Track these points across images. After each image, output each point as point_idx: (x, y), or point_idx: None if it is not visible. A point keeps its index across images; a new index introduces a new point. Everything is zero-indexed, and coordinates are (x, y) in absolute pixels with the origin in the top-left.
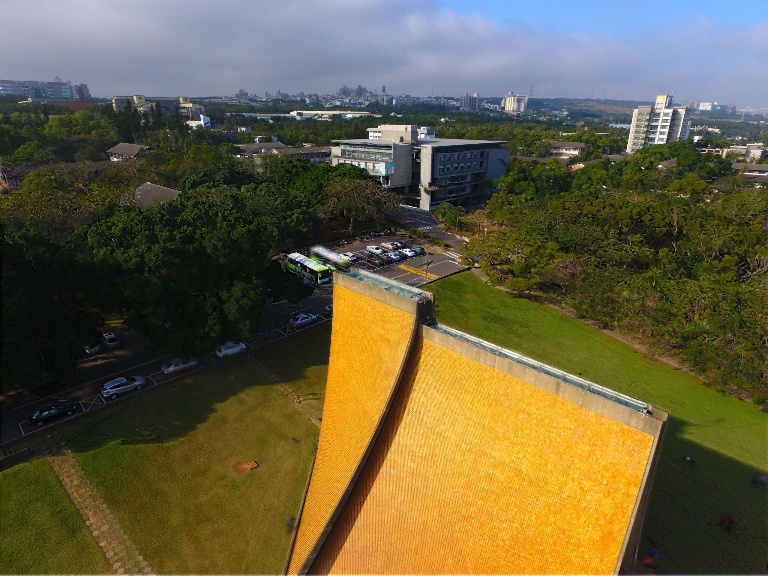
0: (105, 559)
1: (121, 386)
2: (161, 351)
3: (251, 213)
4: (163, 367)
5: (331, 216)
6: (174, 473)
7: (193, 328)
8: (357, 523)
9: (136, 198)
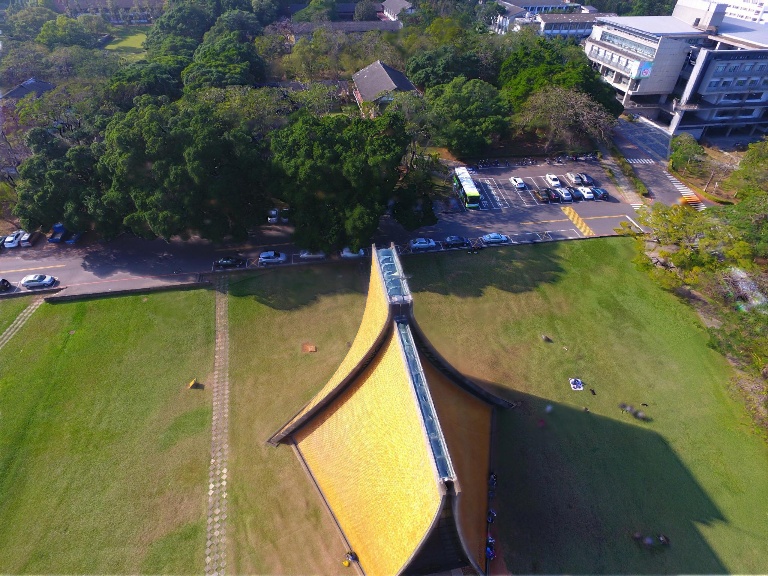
0: (213, 366)
1: (269, 258)
2: (295, 243)
3: (403, 137)
4: (301, 252)
5: (521, 132)
6: (270, 332)
7: (320, 232)
8: (324, 424)
9: (363, 78)
